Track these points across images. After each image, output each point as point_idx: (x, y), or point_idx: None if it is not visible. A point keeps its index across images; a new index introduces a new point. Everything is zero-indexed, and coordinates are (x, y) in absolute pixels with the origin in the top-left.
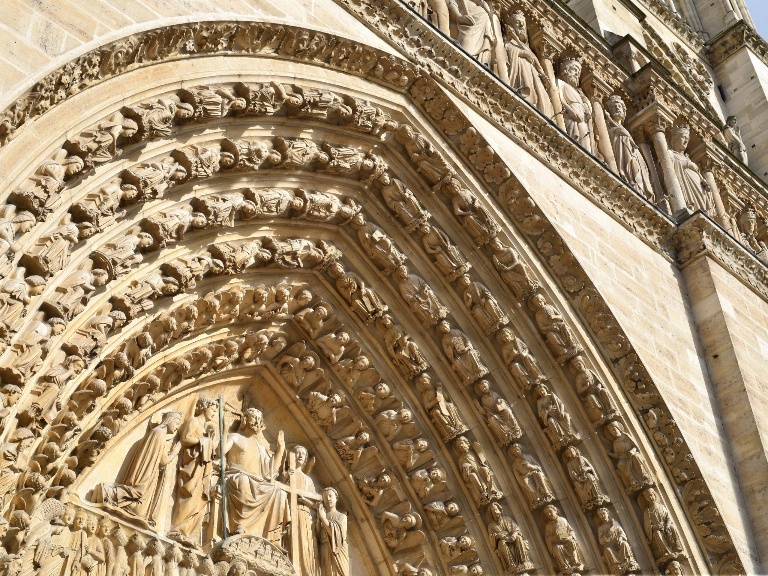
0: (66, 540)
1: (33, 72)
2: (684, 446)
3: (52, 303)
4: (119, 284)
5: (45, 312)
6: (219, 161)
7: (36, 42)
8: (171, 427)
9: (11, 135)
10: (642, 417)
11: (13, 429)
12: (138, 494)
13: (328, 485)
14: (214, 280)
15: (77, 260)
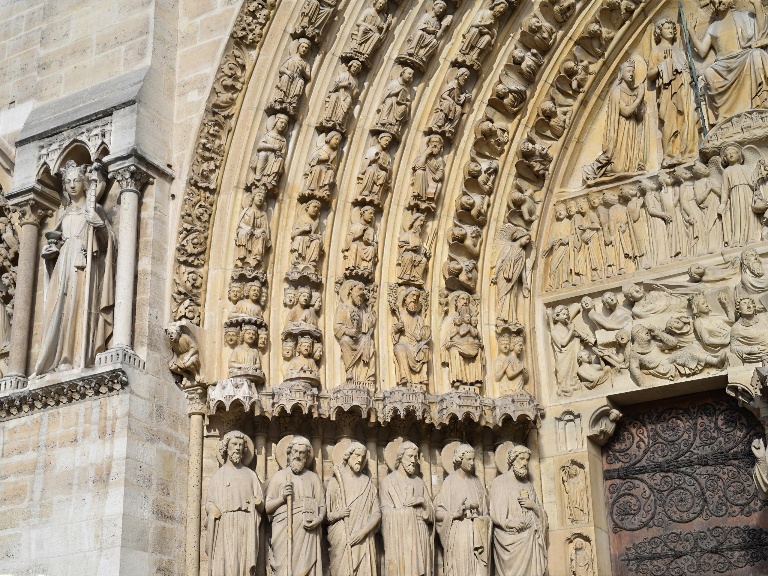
0: (565, 231)
1: (227, 30)
2: None
3: (374, 127)
4: (451, 49)
5: (377, 135)
6: None
7: (225, 4)
8: (625, 78)
9: (242, 79)
10: None
11: (409, 220)
12: (606, 159)
13: None
14: None
15: (384, 78)
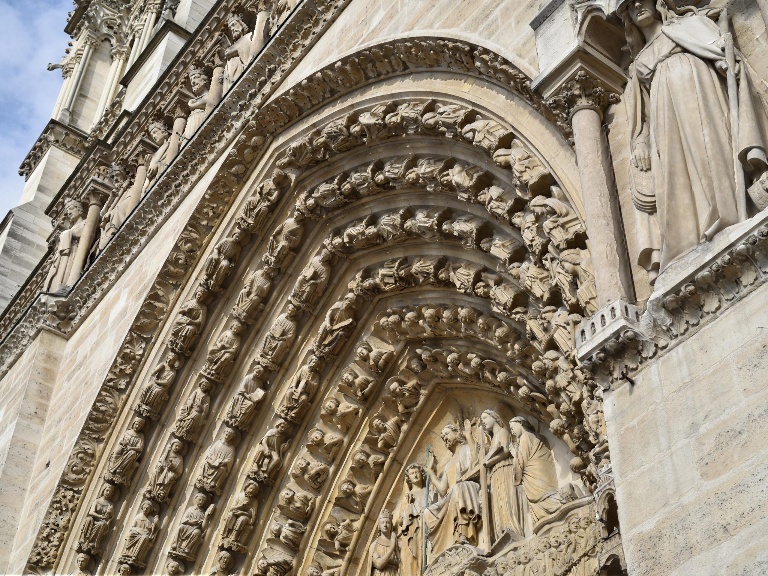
0: None
1: None
2: (497, 55)
3: None
4: (218, 535)
5: None
6: (205, 392)
7: None
8: (381, 530)
9: None
10: (485, 76)
11: None
12: None
13: (525, 411)
14: (312, 419)
15: (159, 574)
